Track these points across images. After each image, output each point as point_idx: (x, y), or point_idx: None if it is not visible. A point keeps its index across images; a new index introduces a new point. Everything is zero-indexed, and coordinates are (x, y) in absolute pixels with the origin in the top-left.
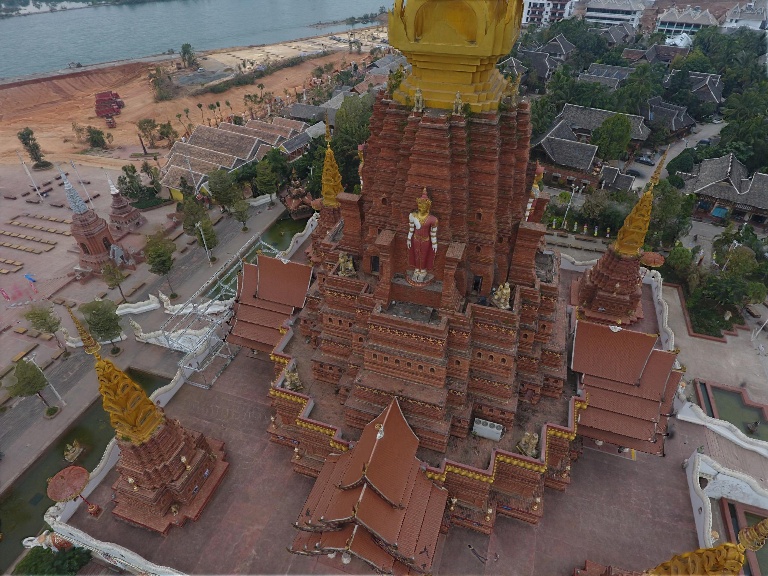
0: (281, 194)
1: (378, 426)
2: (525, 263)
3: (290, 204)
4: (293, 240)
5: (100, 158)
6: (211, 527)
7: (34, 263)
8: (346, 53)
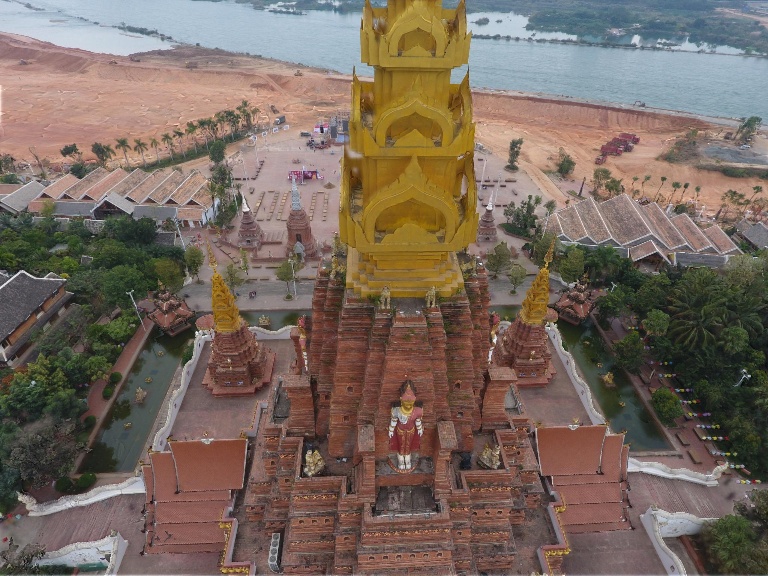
0: (588, 290)
1: (204, 433)
2: (365, 468)
3: (563, 300)
4: None
5: (549, 182)
6: (212, 407)
7: None
8: None
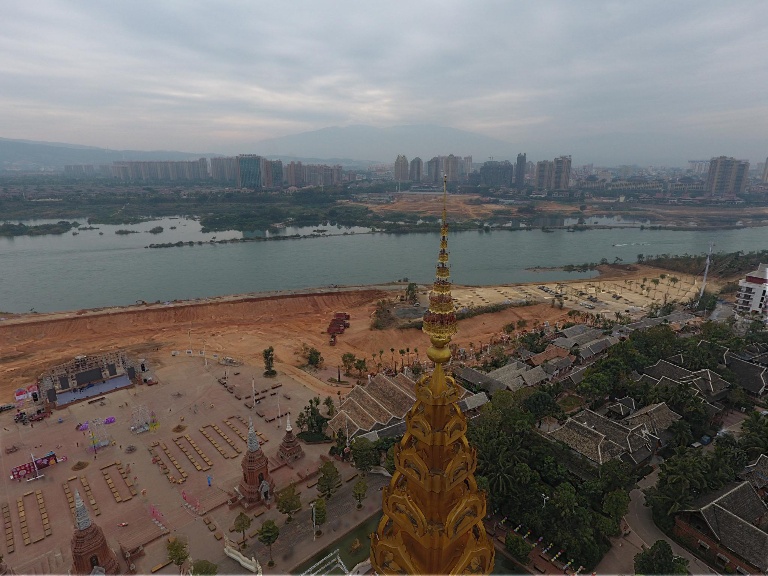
0: None
1: None
2: None
3: None
4: None
5: (308, 376)
6: None
7: (219, 467)
8: (548, 306)
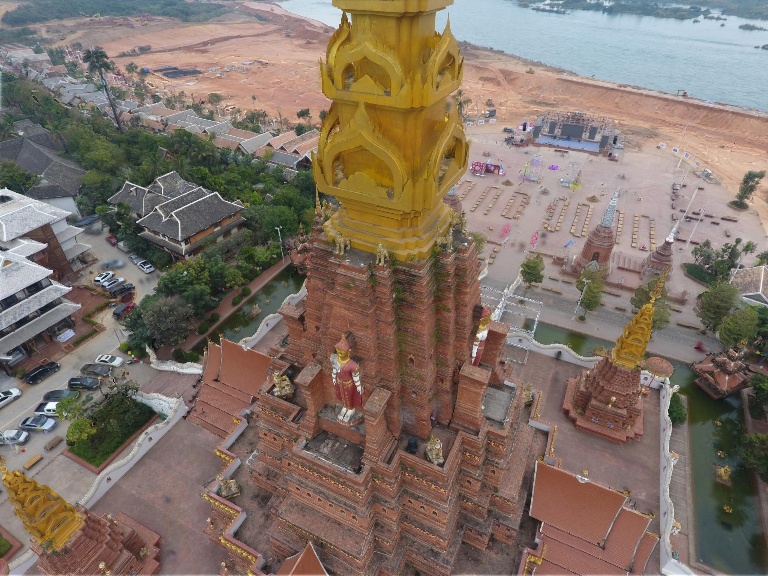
0: (757, 365)
1: (244, 340)
2: None
3: (705, 363)
4: (597, 358)
5: None
6: None
7: None
8: None
